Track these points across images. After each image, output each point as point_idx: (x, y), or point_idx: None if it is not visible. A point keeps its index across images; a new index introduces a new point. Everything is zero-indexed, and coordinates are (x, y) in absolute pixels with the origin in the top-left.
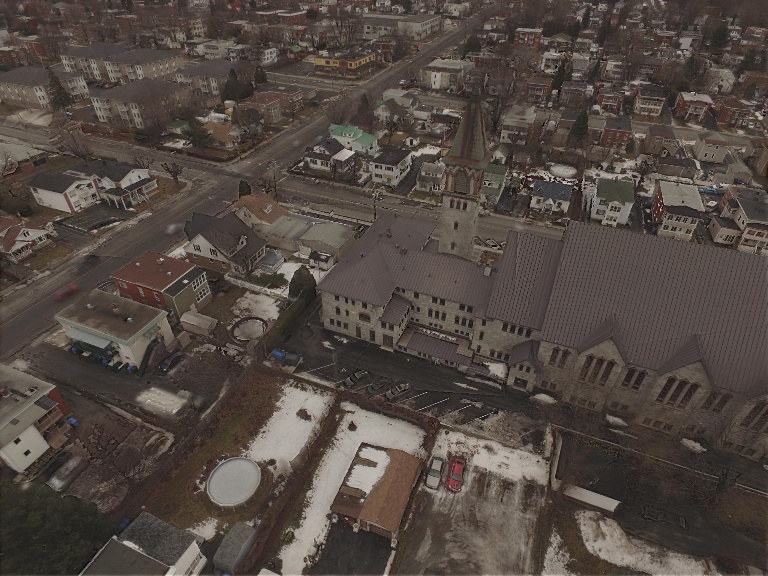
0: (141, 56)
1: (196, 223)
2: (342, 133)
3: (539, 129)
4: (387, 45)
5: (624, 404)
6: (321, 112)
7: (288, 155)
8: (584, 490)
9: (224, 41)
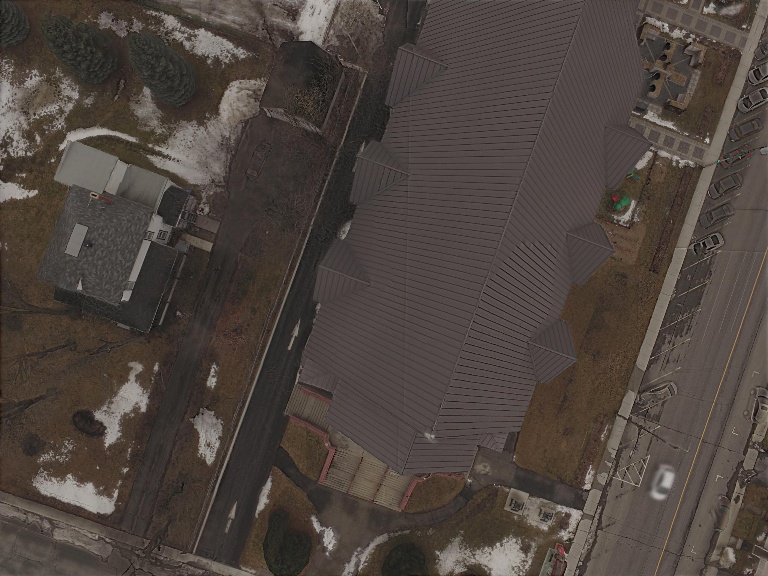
0: None
1: None
2: None
3: None
4: None
5: None
6: None
7: None
8: None
9: None
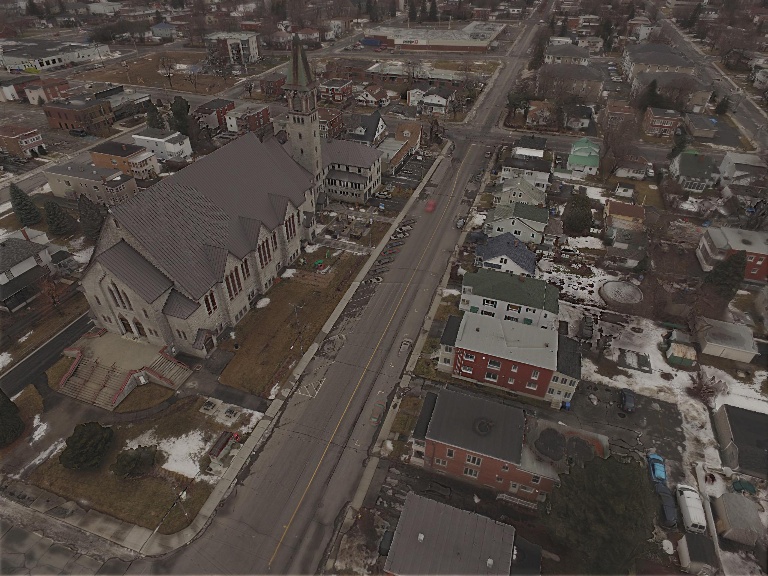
0: (649, 57)
1: None
2: (574, 145)
3: None
4: None
5: None
6: (667, 146)
7: None
8: None
9: None
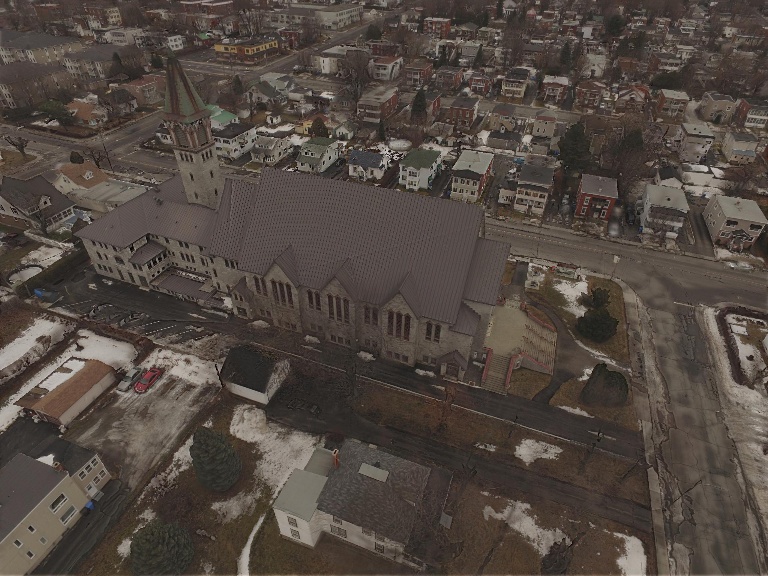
0: (33, 41)
1: (5, 186)
2: None
3: (401, 109)
4: (293, 33)
5: (318, 325)
6: None
7: (149, 132)
8: (238, 386)
9: (132, 29)
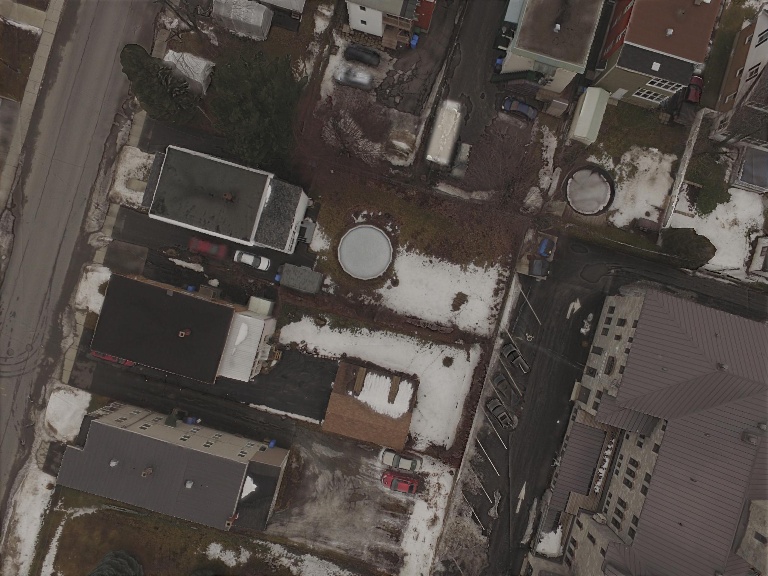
0: None
1: None
2: None
3: None
4: None
5: None
6: None
7: None
8: None
9: None
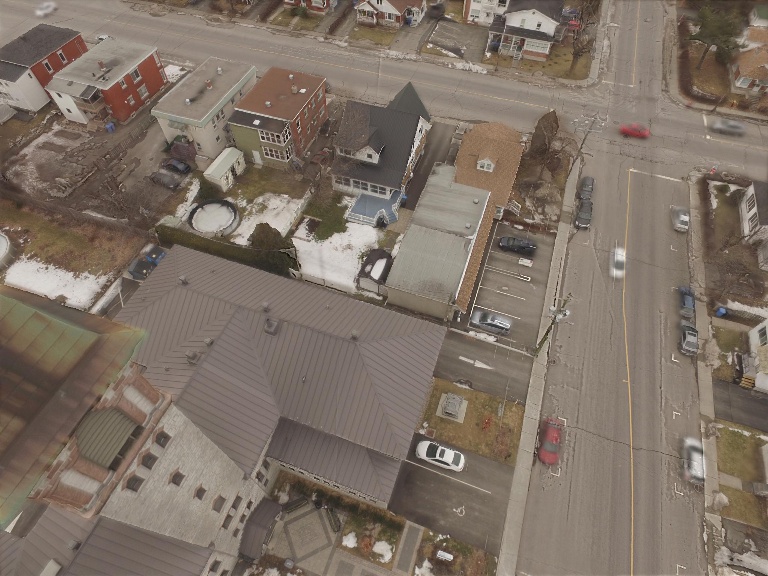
0: None
1: None
2: None
3: None
4: None
5: None
6: None
7: None
8: None
9: None
